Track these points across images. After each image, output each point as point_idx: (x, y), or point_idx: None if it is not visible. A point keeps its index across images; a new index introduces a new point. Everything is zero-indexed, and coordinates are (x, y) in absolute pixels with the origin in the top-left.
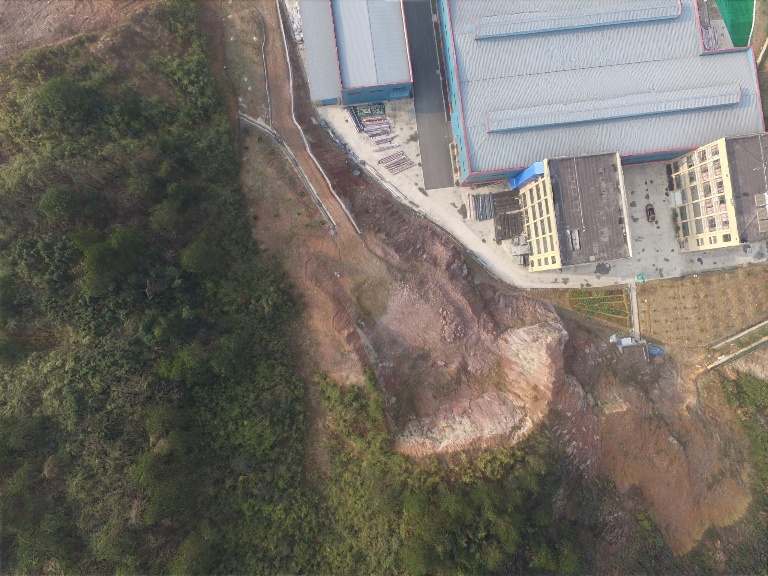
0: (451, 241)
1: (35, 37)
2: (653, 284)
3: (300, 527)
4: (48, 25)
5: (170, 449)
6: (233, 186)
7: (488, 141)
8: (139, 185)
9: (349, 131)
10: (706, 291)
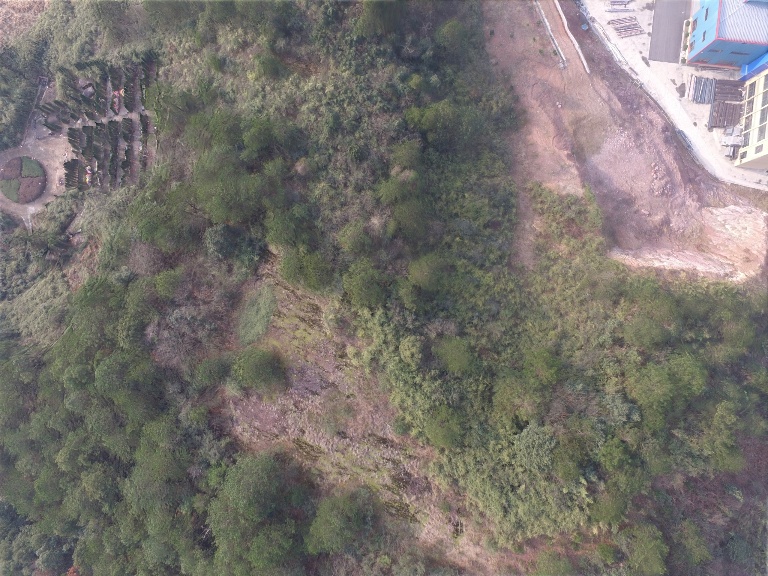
0: (662, 116)
1: None
2: None
3: (506, 298)
4: None
5: (414, 180)
6: (476, 0)
7: (742, 11)
8: None
9: None
10: None
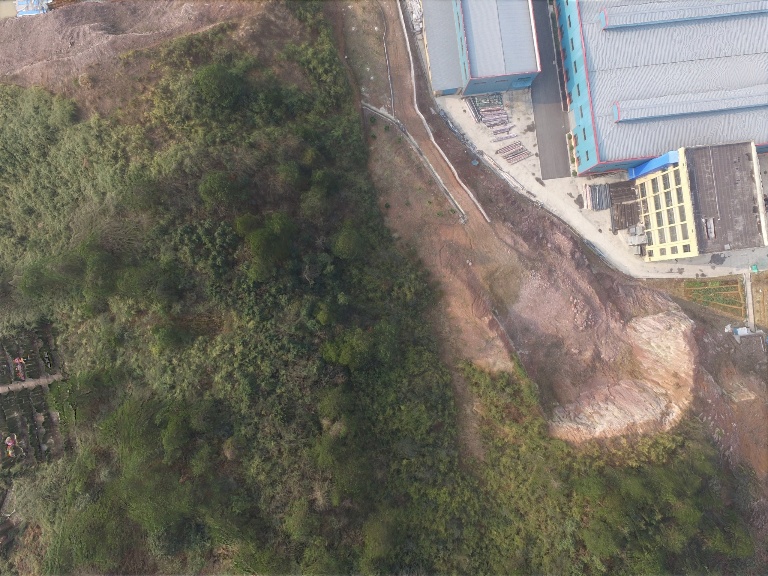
0: (568, 231)
1: (174, 25)
2: (767, 274)
3: (465, 510)
4: (187, 13)
5: (346, 432)
6: (363, 175)
7: (616, 131)
8: (289, 172)
9: (467, 121)
10: None
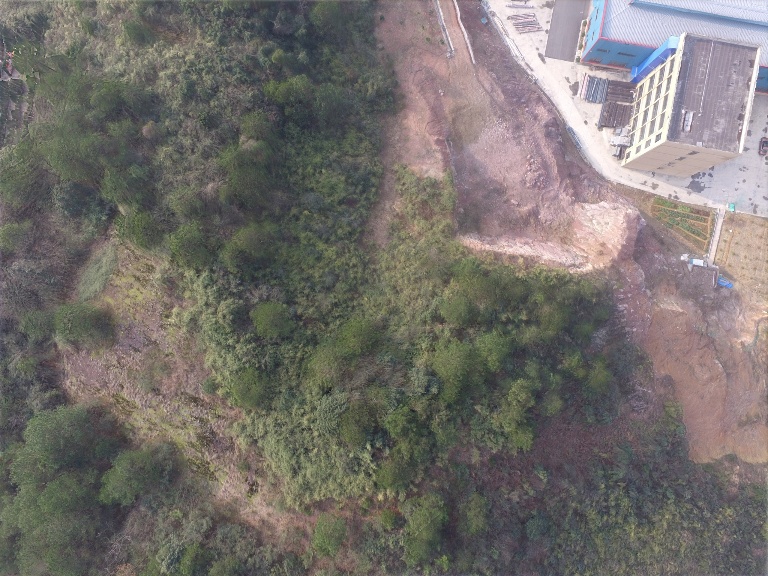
0: (554, 113)
1: None
2: (743, 217)
3: (346, 272)
4: None
5: (257, 149)
6: None
7: (627, 13)
8: None
9: None
10: None
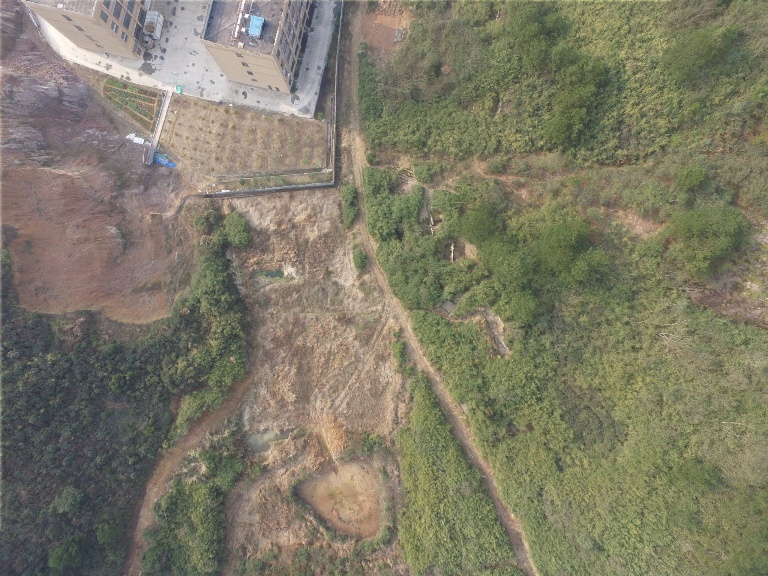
0: None
1: None
2: (189, 99)
3: None
4: None
5: None
6: None
7: None
8: None
9: None
10: (236, 123)
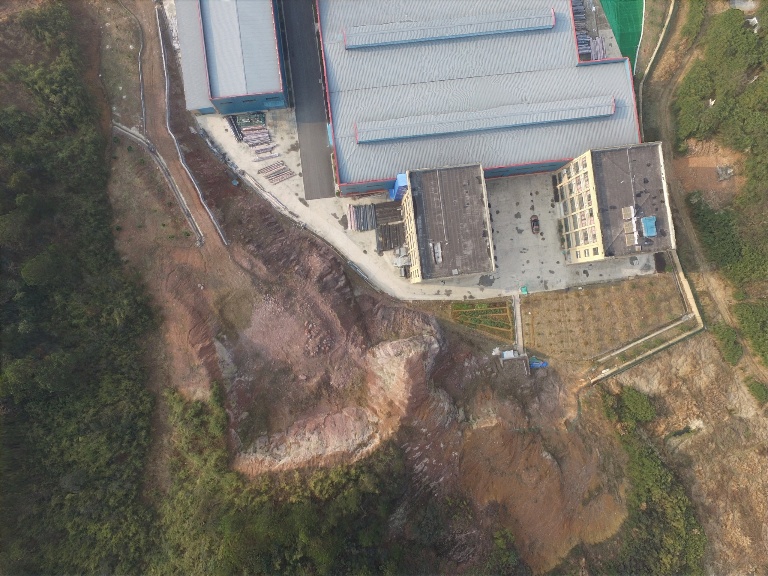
0: (331, 252)
1: None
2: (537, 296)
3: (126, 547)
4: None
5: None
6: (98, 196)
7: (358, 152)
8: None
9: (229, 140)
10: (591, 304)
